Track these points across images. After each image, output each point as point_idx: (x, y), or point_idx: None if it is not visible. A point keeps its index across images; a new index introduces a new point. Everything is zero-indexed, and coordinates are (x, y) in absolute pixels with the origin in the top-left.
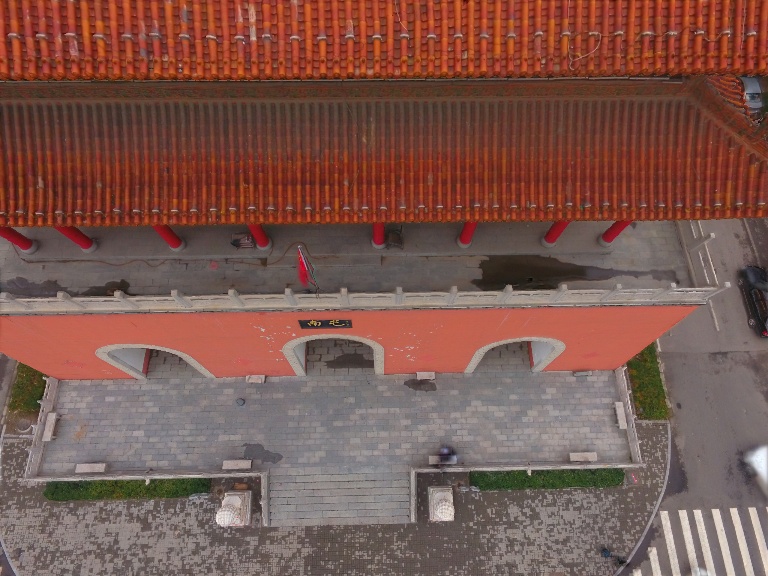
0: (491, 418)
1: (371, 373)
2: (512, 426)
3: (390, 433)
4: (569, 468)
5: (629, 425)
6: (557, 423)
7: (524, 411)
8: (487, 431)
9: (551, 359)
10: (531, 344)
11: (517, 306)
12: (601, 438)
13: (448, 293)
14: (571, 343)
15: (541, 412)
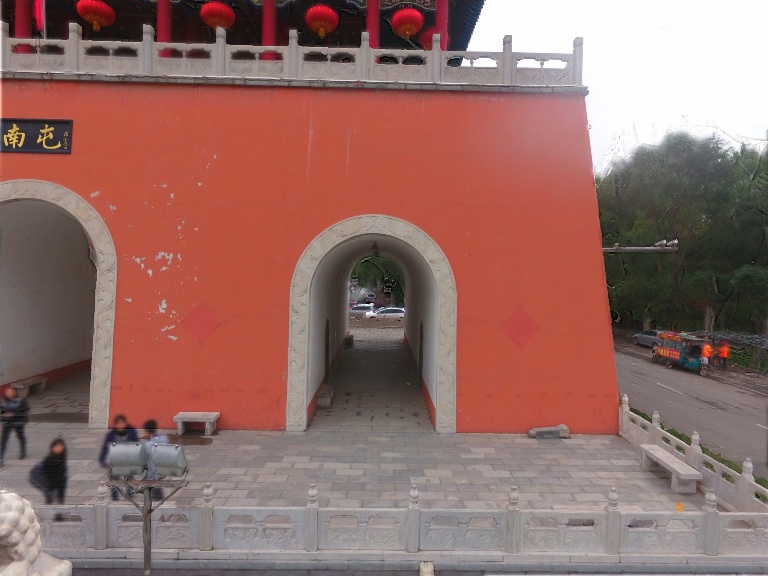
0: (325, 476)
1: (82, 427)
2: (380, 487)
3: (19, 490)
4: (571, 560)
5: (705, 478)
6: (507, 486)
7: (416, 470)
8: (305, 493)
9: (450, 345)
10: (430, 395)
11: (314, 79)
12: (647, 509)
13: (214, 44)
14: (457, 258)
15: (461, 471)
